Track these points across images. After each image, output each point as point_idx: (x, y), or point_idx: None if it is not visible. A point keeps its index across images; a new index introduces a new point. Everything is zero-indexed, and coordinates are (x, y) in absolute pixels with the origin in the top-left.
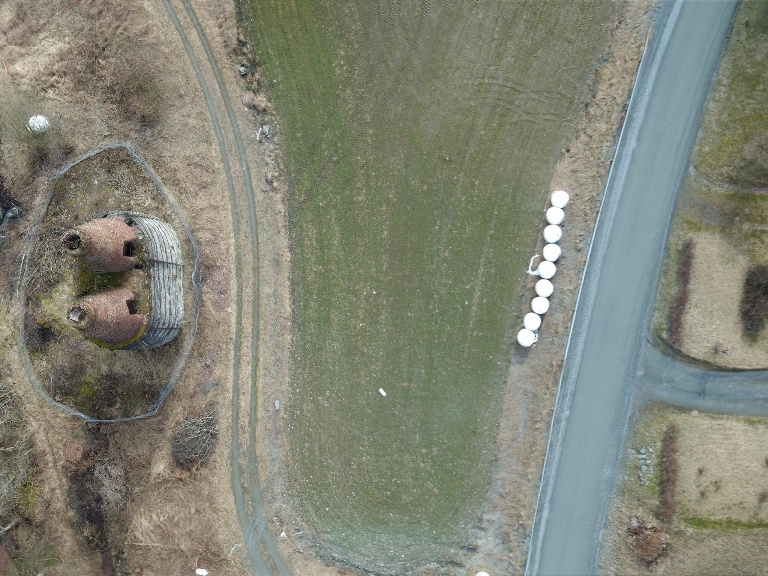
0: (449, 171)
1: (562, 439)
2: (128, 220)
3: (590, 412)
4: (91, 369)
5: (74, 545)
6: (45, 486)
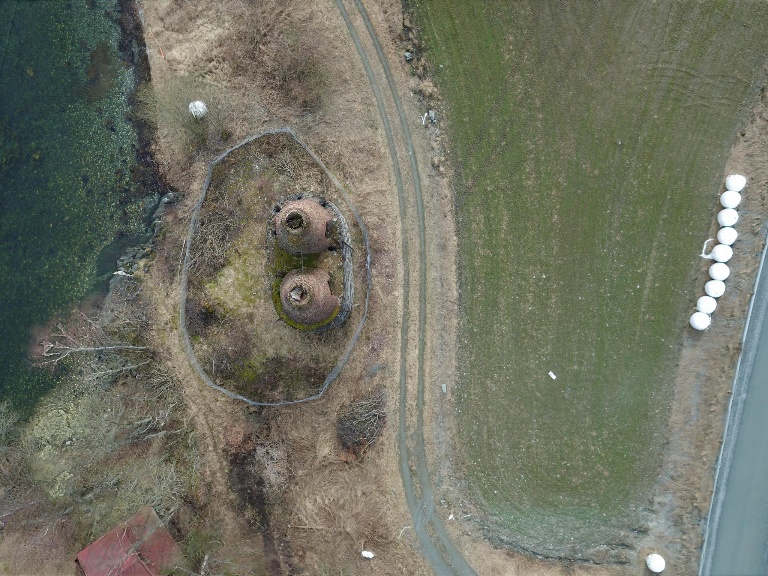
0: (621, 155)
1: (738, 422)
2: (322, 202)
3: (767, 395)
4: (257, 353)
5: (236, 528)
6: (206, 469)
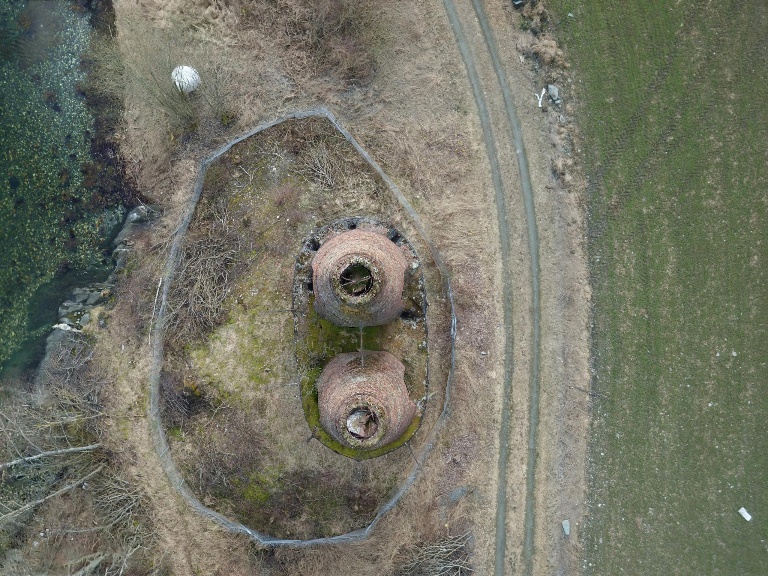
0: None
1: None
2: (391, 234)
3: None
4: (269, 462)
5: None
6: None
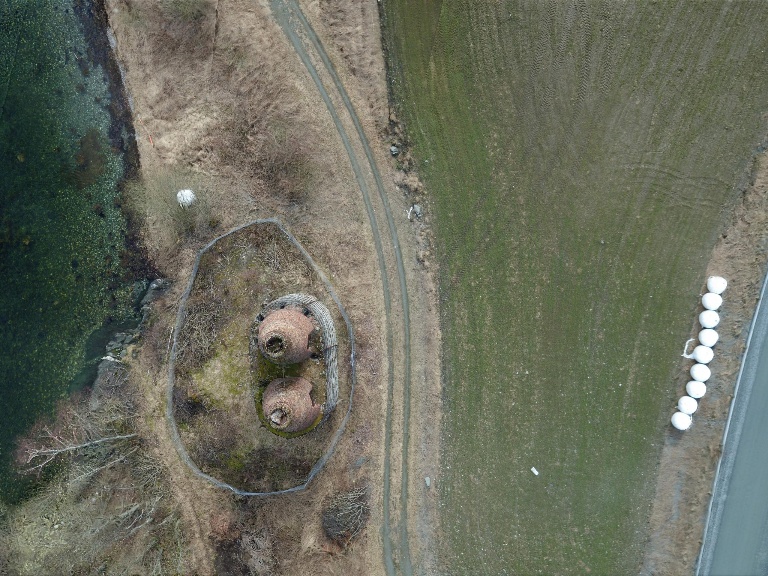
0: (604, 254)
1: (719, 523)
2: (305, 310)
3: (747, 496)
4: (242, 444)
5: None
6: (192, 557)
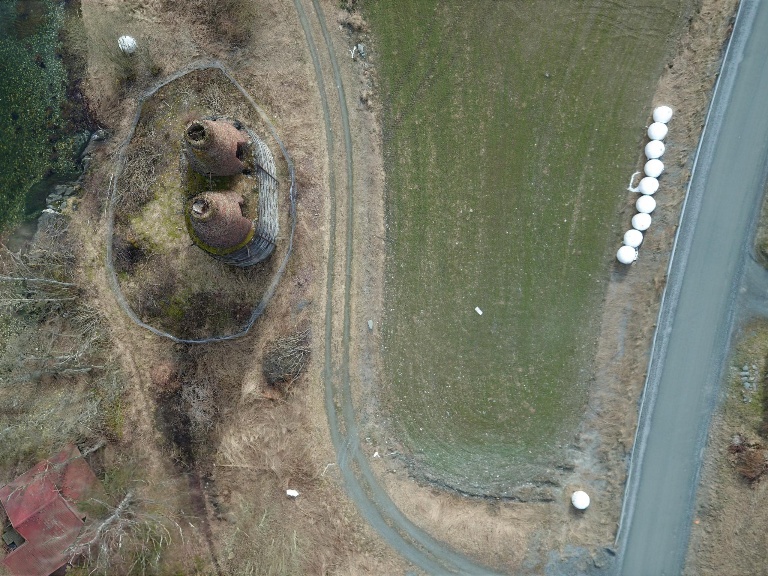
0: (549, 88)
1: (664, 356)
2: (237, 125)
3: (692, 329)
4: (182, 288)
5: (161, 467)
6: (132, 408)
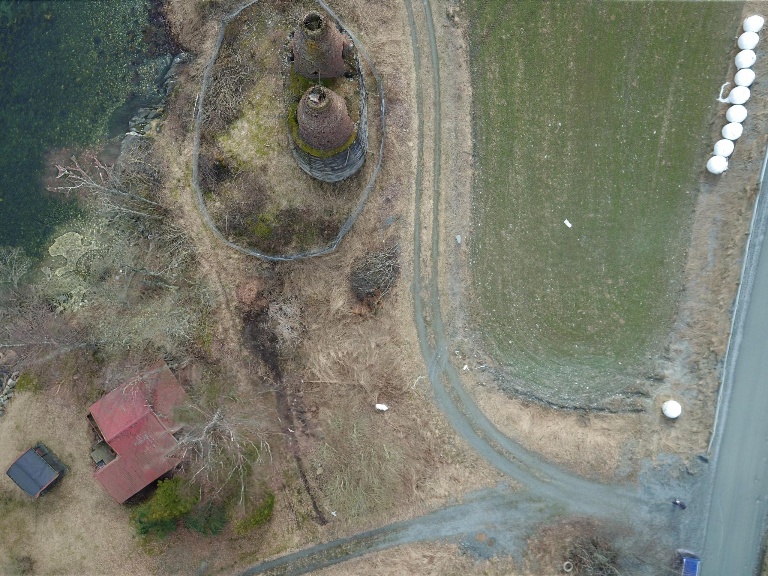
0: None
1: (756, 264)
2: (338, 28)
3: None
4: (270, 205)
5: (248, 385)
6: (218, 327)
